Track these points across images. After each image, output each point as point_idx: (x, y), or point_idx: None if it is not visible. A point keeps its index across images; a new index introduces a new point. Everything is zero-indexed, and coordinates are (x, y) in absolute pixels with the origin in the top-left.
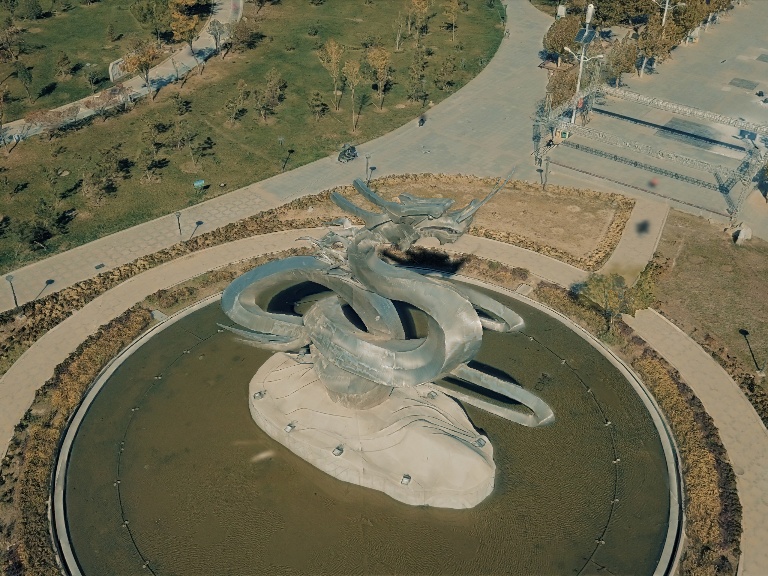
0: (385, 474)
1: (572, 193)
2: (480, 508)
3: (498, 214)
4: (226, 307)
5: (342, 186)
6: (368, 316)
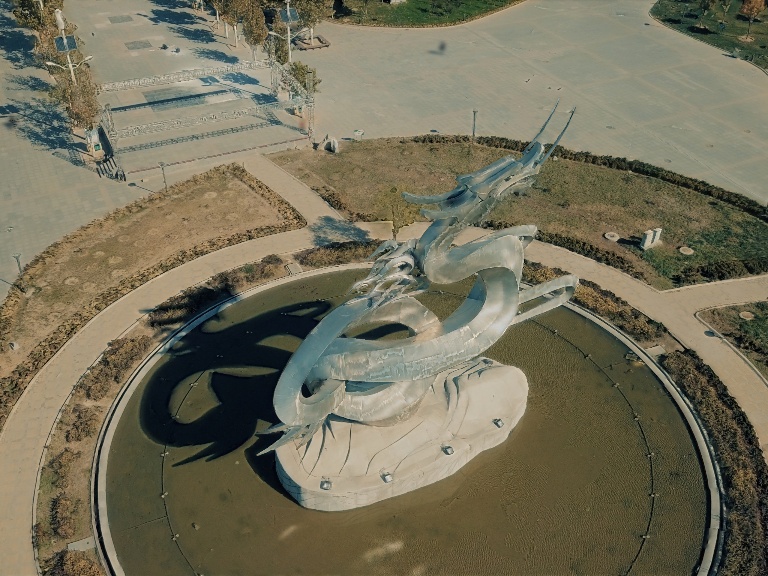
0: (484, 434)
1: (188, 185)
2: (528, 402)
3: (172, 235)
4: (290, 419)
5: (1, 306)
6: (416, 319)
